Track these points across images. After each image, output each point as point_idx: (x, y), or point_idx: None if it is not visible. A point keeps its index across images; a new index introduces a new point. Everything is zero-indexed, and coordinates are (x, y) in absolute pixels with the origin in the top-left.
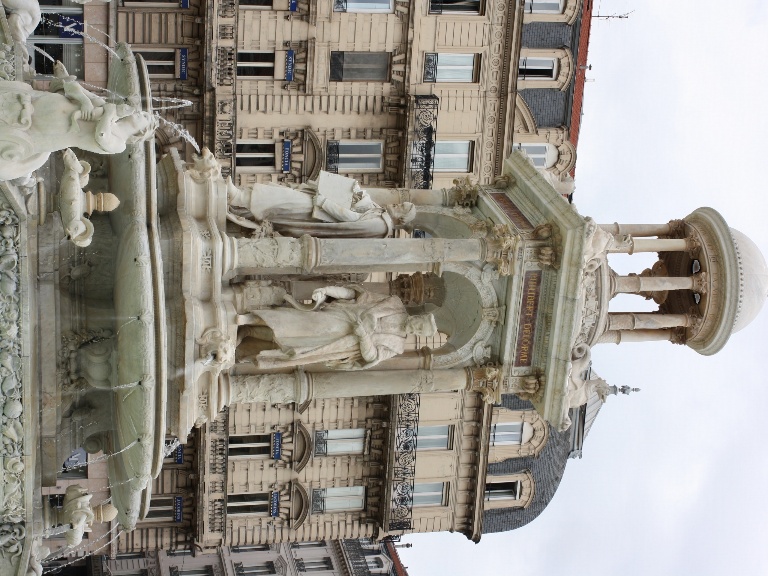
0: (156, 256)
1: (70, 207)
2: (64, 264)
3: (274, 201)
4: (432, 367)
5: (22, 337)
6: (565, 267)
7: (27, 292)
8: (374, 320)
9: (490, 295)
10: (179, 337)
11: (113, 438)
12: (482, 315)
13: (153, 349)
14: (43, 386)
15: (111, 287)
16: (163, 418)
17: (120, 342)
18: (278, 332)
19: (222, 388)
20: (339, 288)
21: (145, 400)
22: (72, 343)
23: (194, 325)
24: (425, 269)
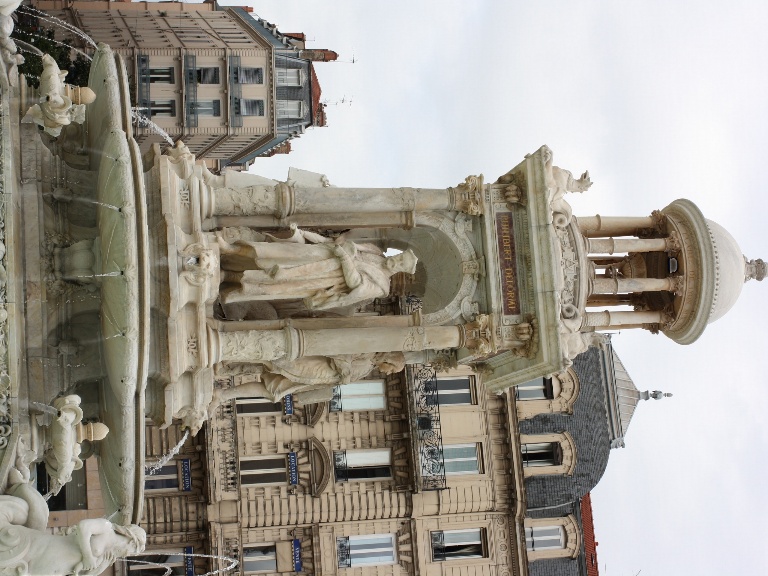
0: (132, 139)
1: (49, 81)
2: (47, 182)
3: (248, 183)
4: (422, 324)
5: (4, 173)
6: (532, 196)
7: (9, 133)
8: (353, 243)
9: (467, 248)
10: (161, 247)
11: (103, 397)
12: (463, 269)
13: (132, 186)
14: (27, 274)
15: (93, 219)
16: (146, 255)
17: (101, 216)
18: (259, 249)
19: (211, 334)
20: (317, 234)
21: (126, 226)
22: (55, 237)
23: (175, 234)
24: (399, 221)
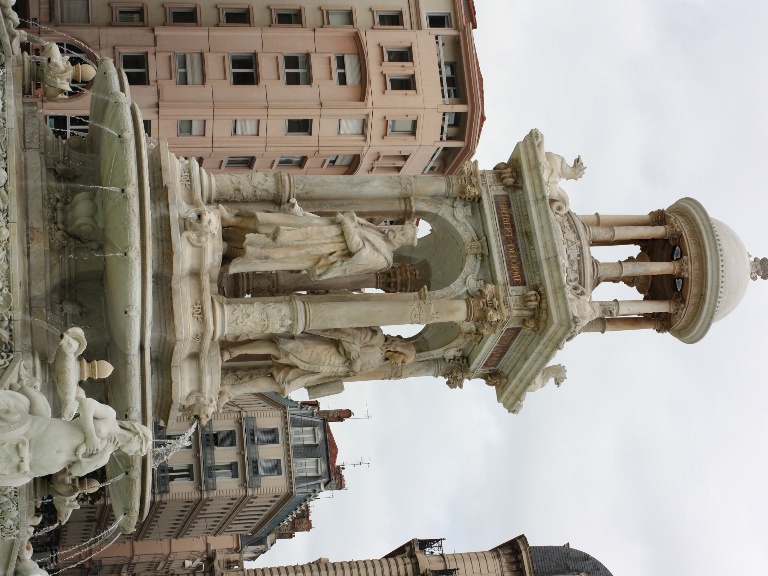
0: None
1: (50, 52)
2: (49, 158)
3: None
4: None
5: (6, 111)
6: (527, 174)
7: (11, 80)
8: None
9: (468, 232)
10: (163, 209)
11: None
12: (465, 250)
13: (131, 121)
14: (30, 222)
15: None
16: (146, 178)
17: None
18: (260, 214)
19: (216, 302)
20: None
21: (126, 149)
22: (58, 193)
23: None
24: (398, 208)
